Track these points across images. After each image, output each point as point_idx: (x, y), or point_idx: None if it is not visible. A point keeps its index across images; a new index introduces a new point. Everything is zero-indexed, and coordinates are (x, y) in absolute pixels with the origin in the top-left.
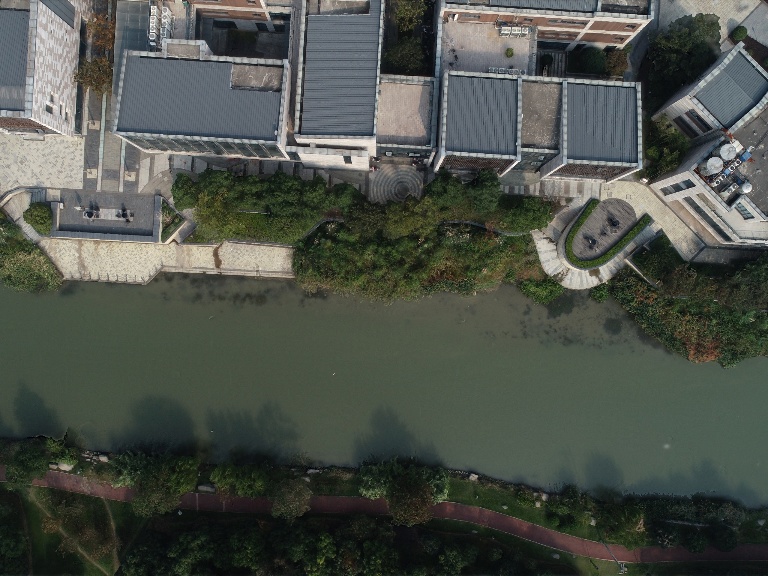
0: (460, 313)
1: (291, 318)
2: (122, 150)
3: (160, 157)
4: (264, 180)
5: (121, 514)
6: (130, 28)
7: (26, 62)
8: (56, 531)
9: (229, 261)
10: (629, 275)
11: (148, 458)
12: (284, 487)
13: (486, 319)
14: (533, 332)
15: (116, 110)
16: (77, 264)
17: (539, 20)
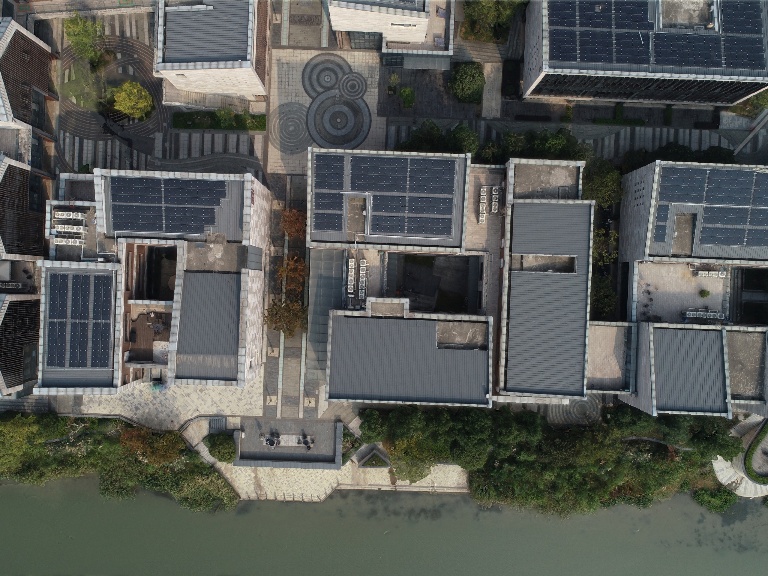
0: (634, 523)
1: None
2: (301, 376)
3: None
4: (452, 414)
5: None
6: (324, 276)
7: (235, 329)
8: None
9: None
10: None
11: None
12: None
13: (660, 528)
14: (707, 540)
15: (326, 376)
16: (253, 484)
17: None
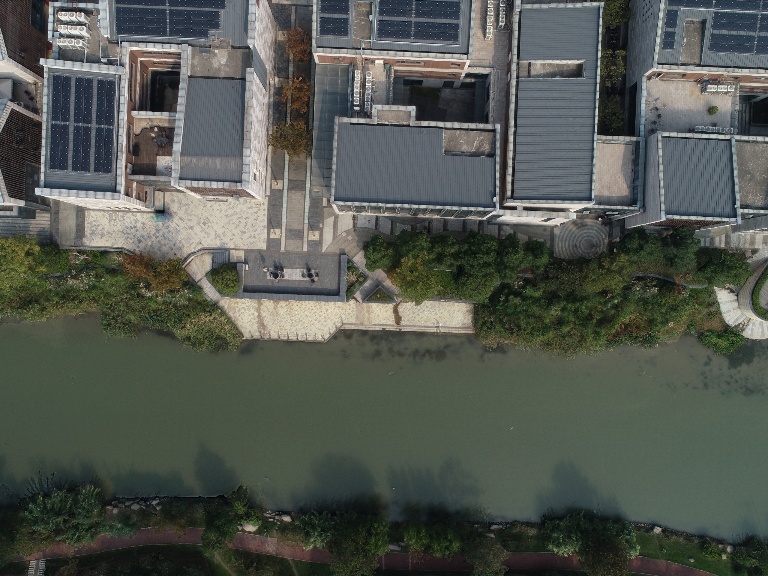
0: (640, 365)
1: (470, 373)
2: (305, 209)
3: (344, 216)
4: (458, 240)
5: (307, 574)
6: (330, 92)
7: (239, 132)
8: None
9: (409, 317)
10: None
11: (335, 518)
12: (479, 547)
13: (667, 371)
14: (714, 383)
15: (332, 179)
16: (256, 323)
17: (745, 78)
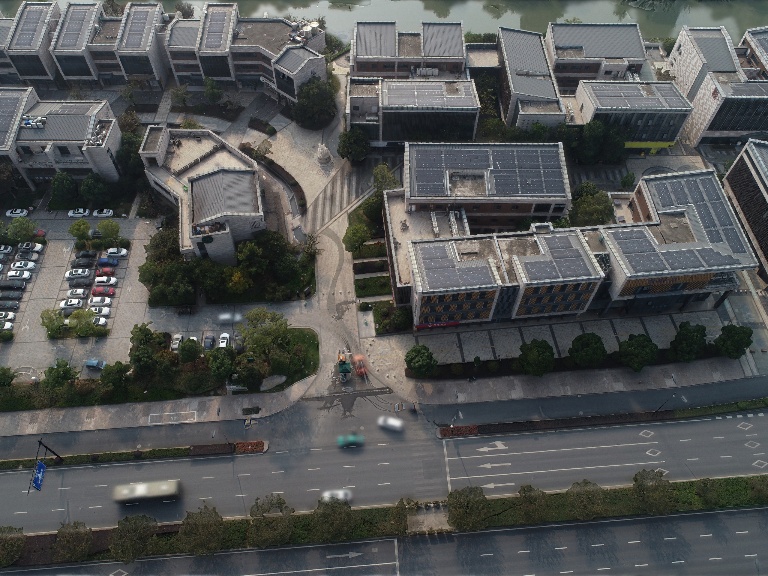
0: None
1: None
2: None
3: None
4: None
5: None
6: None
7: None
8: None
9: None
10: (337, 46)
11: None
12: None
13: None
14: None
15: None
16: None
17: None
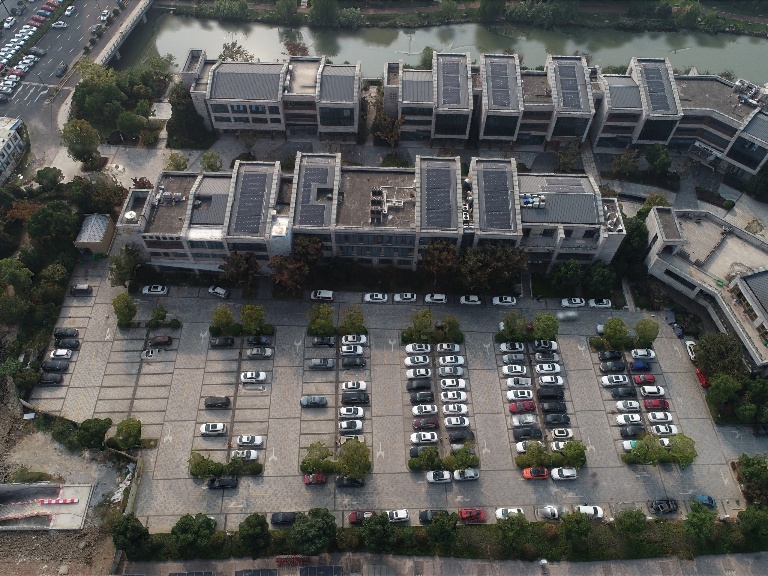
0: None
1: None
2: None
3: None
4: None
5: None
6: None
7: None
8: None
9: None
10: None
11: None
12: None
13: None
14: None
15: None
16: None
17: None
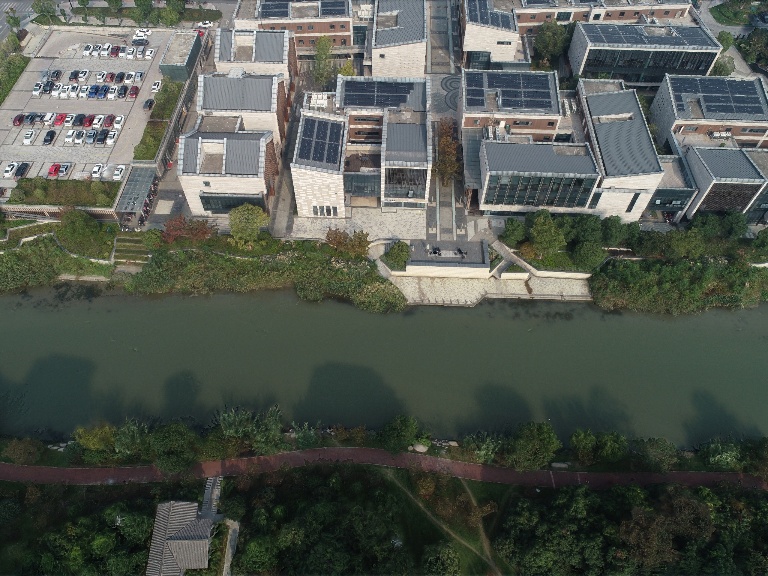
0: (735, 323)
1: None
2: (453, 217)
3: (481, 221)
4: None
5: (480, 492)
6: (472, 140)
7: (422, 142)
8: (432, 492)
9: (538, 289)
10: None
11: None
12: None
13: (758, 327)
14: None
15: (486, 162)
16: (418, 293)
17: (736, 129)
